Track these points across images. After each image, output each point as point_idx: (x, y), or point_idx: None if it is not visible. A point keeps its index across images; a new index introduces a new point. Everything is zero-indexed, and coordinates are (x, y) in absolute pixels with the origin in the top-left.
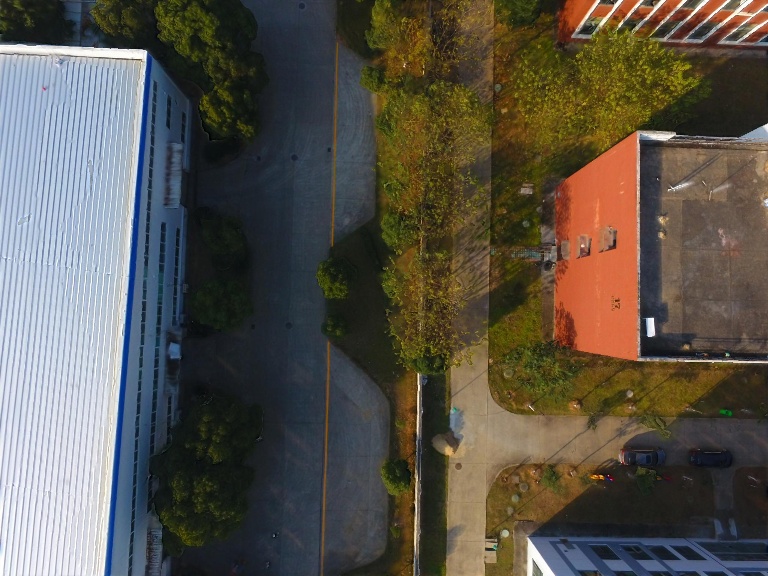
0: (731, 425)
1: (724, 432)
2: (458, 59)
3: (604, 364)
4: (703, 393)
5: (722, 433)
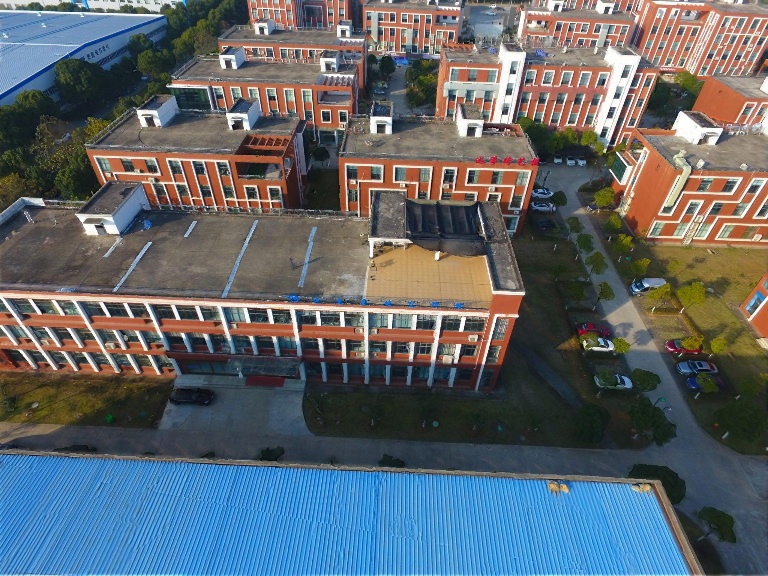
0: (113, 432)
1: (103, 438)
2: (2, 203)
3: (28, 382)
4: (102, 406)
5: (101, 439)
